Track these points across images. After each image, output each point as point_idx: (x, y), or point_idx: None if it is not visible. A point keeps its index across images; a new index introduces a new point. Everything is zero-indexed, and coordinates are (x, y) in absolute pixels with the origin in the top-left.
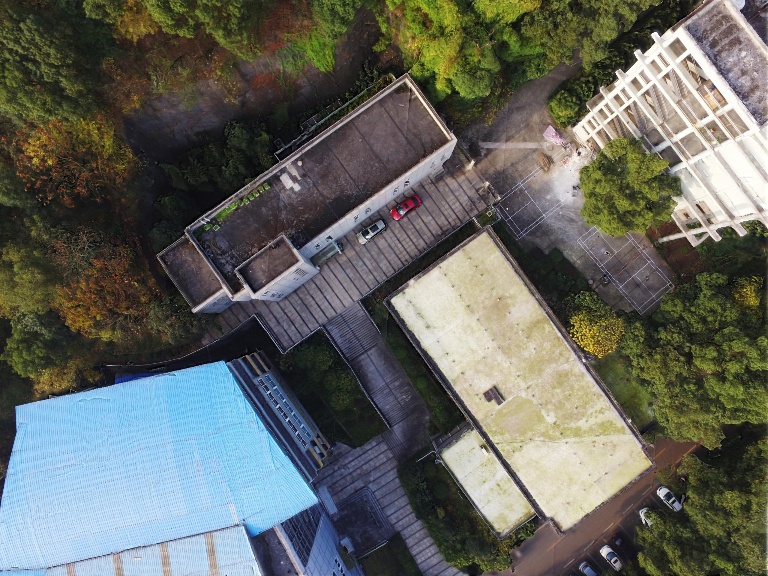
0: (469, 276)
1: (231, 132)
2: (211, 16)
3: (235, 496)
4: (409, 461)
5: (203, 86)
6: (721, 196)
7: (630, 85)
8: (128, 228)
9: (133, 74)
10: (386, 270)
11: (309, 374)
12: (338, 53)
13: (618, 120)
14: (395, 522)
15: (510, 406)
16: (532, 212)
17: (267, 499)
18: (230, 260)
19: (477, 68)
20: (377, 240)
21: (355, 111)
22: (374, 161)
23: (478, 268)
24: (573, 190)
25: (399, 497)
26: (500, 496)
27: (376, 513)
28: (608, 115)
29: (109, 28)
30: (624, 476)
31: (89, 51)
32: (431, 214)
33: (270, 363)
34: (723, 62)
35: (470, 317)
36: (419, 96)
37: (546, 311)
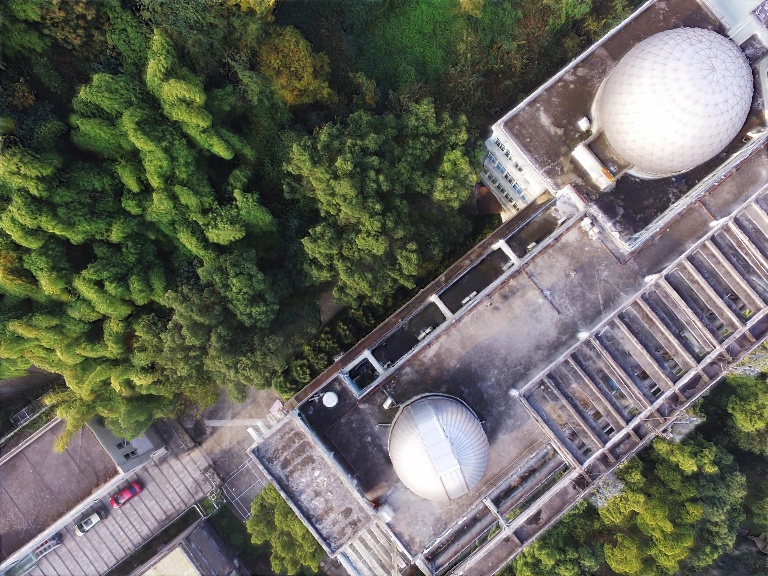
0: None
1: None
2: None
3: None
4: None
5: None
6: None
7: None
8: None
9: None
10: (108, 560)
11: None
12: None
13: None
14: None
15: None
16: (259, 492)
17: None
18: None
19: None
20: (98, 528)
21: (18, 448)
22: (45, 493)
23: None
24: None
25: None
26: None
27: None
28: None
29: None
30: None
31: None
32: (155, 498)
33: None
34: (295, 483)
35: None
36: None
37: None
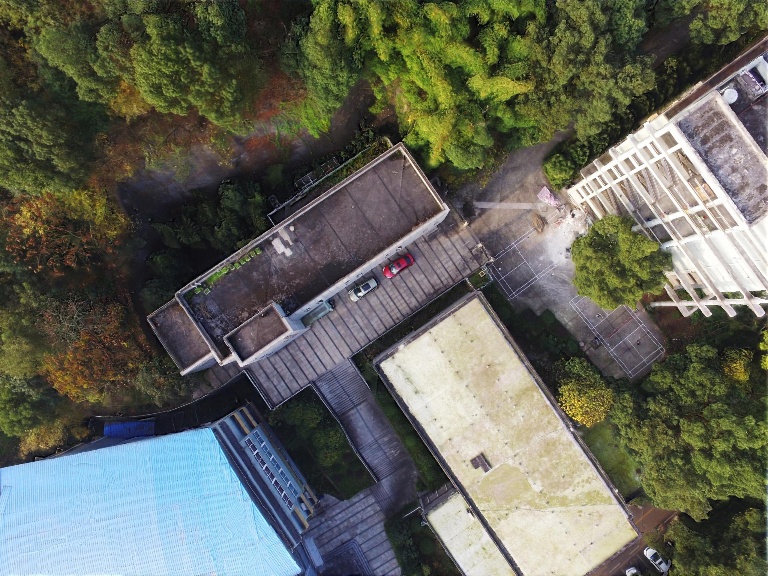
0: (459, 342)
1: (225, 193)
2: (204, 100)
3: (218, 566)
4: (396, 516)
5: (197, 151)
6: (713, 270)
7: (623, 163)
8: (120, 284)
9: (127, 144)
10: (377, 328)
11: (297, 431)
12: (334, 116)
13: (611, 191)
14: (381, 575)
15: (497, 473)
16: (525, 273)
17: (250, 570)
18: (220, 324)
19: (470, 143)
20: (369, 297)
21: (348, 179)
22: (366, 228)
23: (468, 334)
24: (566, 252)
25: (385, 550)
26: (485, 560)
27: (362, 566)
28: (602, 185)
29: (102, 107)
30: (609, 547)
31: (82, 128)
32: (424, 272)
33: (259, 415)
34: (714, 159)
35: (459, 383)
36: (413, 165)
37: (535, 379)
